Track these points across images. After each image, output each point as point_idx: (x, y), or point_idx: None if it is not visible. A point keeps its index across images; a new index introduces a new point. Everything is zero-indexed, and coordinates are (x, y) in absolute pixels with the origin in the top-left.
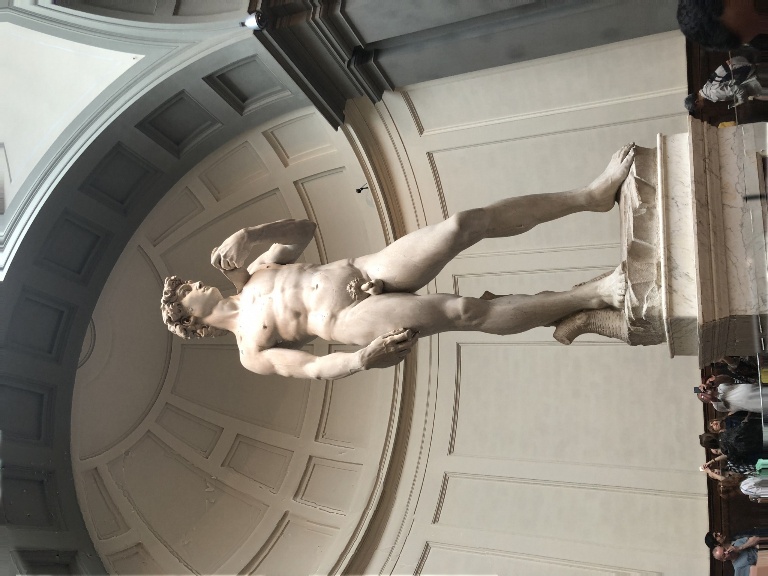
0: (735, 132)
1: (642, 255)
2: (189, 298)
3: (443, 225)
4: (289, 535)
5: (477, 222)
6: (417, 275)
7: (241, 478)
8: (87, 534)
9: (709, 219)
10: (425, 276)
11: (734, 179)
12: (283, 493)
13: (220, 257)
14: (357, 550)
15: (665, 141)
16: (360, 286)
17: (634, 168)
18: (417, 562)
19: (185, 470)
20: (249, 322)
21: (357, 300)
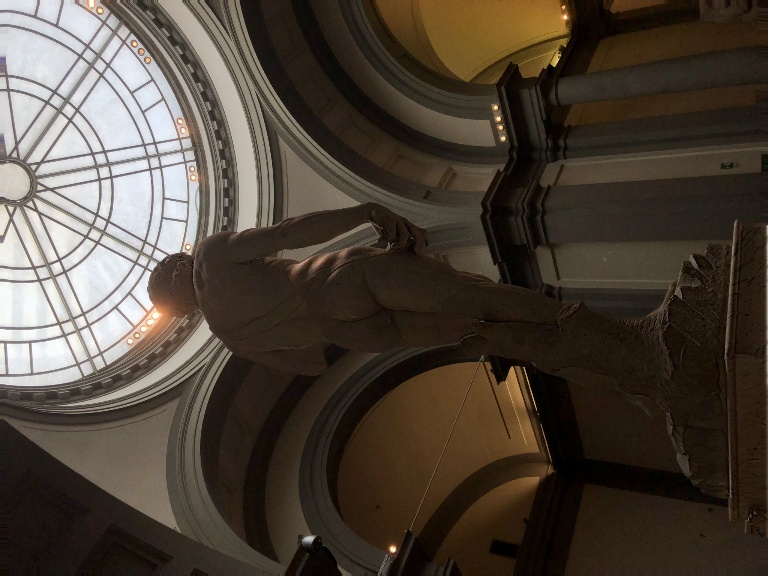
0: None
1: None
2: None
3: None
4: None
5: None
6: None
7: None
8: None
9: None
10: None
11: None
12: None
13: None
14: None
15: None
16: None
17: None
18: None
19: None
20: None
21: None
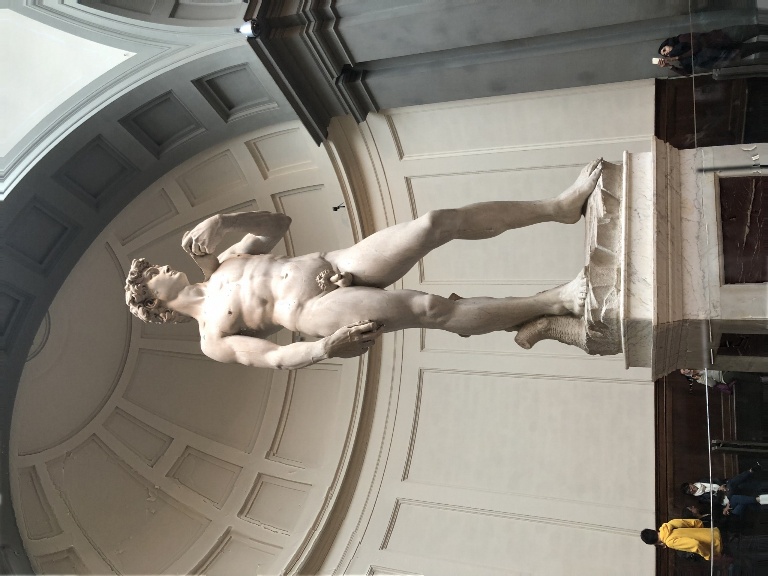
0: (696, 154)
1: (604, 261)
2: (155, 280)
3: (416, 222)
4: (229, 552)
5: (449, 221)
6: (386, 270)
7: (185, 490)
8: (17, 531)
9: (668, 230)
10: (394, 272)
11: (693, 196)
12: (227, 509)
13: (192, 241)
14: (299, 569)
15: (631, 158)
16: (329, 278)
17: (601, 181)
18: None
19: (128, 477)
20: (214, 308)
21: (325, 291)
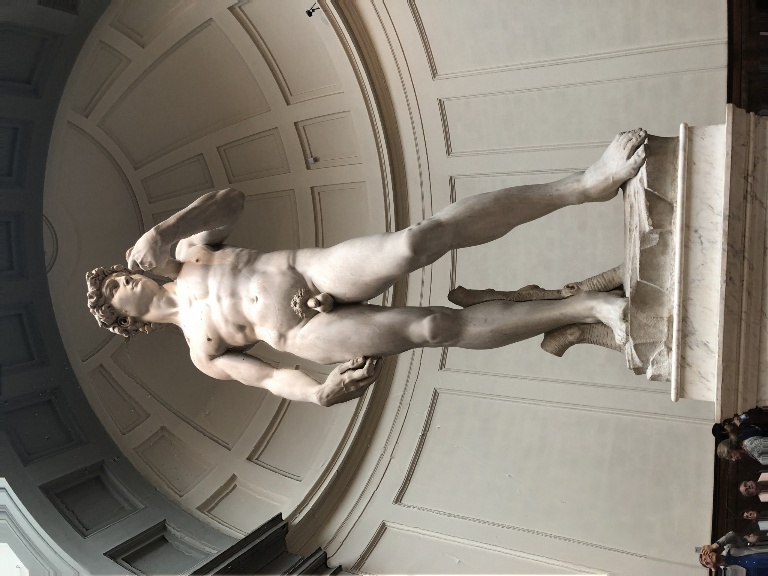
0: None
1: (649, 302)
2: (118, 299)
3: (393, 247)
4: None
5: (436, 242)
6: (371, 291)
7: None
8: (109, 438)
9: (743, 273)
10: (381, 289)
11: None
12: None
13: (136, 263)
14: (368, 405)
15: (692, 136)
16: (306, 301)
17: (645, 175)
18: (427, 410)
19: None
20: (191, 329)
21: (305, 318)
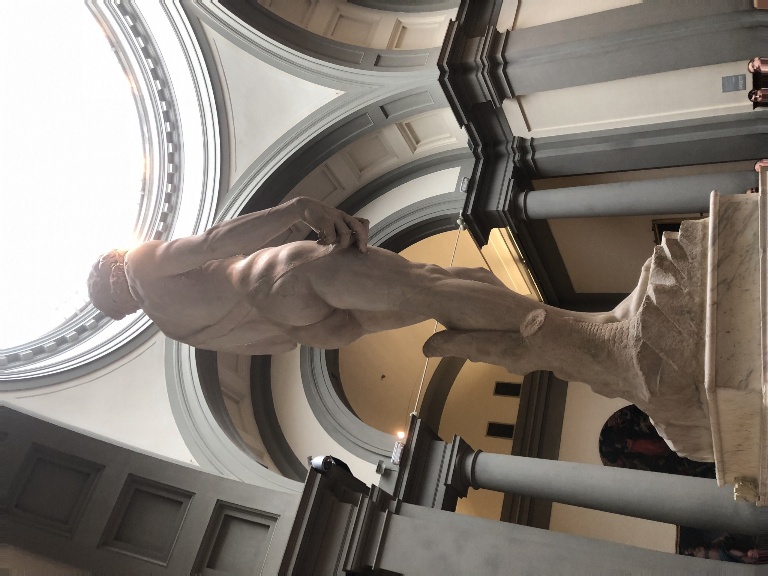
0: None
1: None
2: None
3: None
4: None
5: None
6: None
7: None
8: None
9: None
10: None
11: None
12: None
13: None
14: None
15: None
16: None
17: None
18: None
19: None
20: None
21: None
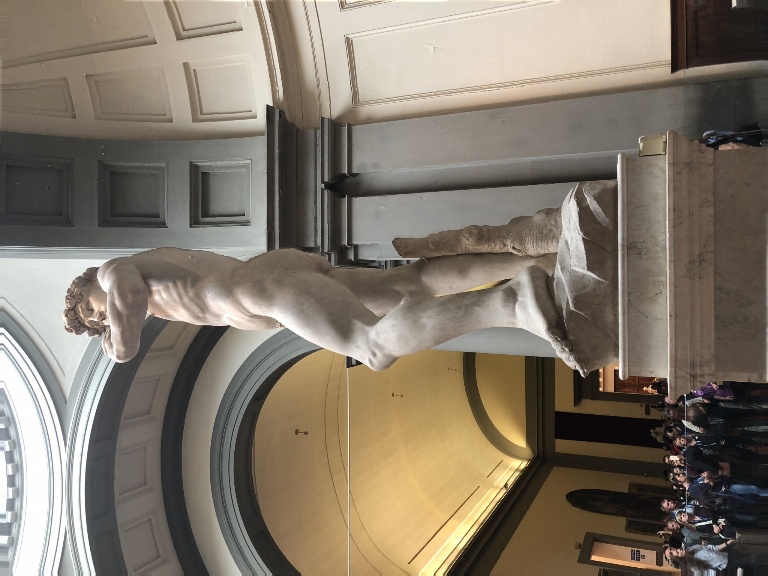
0: None
1: None
2: None
3: None
4: None
5: None
6: None
7: None
8: (76, 139)
9: None
10: None
11: None
12: None
13: None
14: None
15: None
16: None
17: None
18: None
19: None
20: None
21: None
